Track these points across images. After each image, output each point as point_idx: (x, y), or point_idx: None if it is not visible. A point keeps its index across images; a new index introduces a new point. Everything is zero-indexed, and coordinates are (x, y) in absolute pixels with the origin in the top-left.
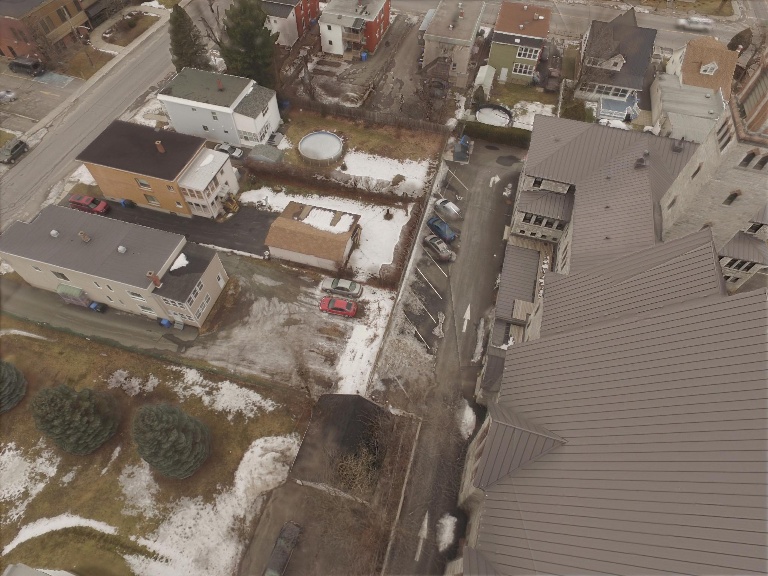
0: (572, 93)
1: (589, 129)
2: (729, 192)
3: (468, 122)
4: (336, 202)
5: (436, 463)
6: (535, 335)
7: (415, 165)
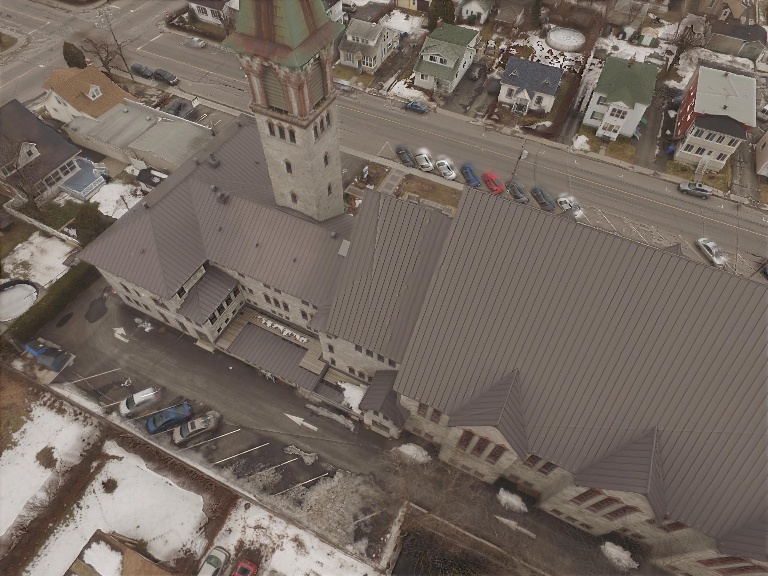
0: (36, 208)
1: (151, 218)
2: (323, 158)
3: (6, 334)
4: (38, 569)
5: (452, 496)
6: (360, 360)
7: (32, 426)
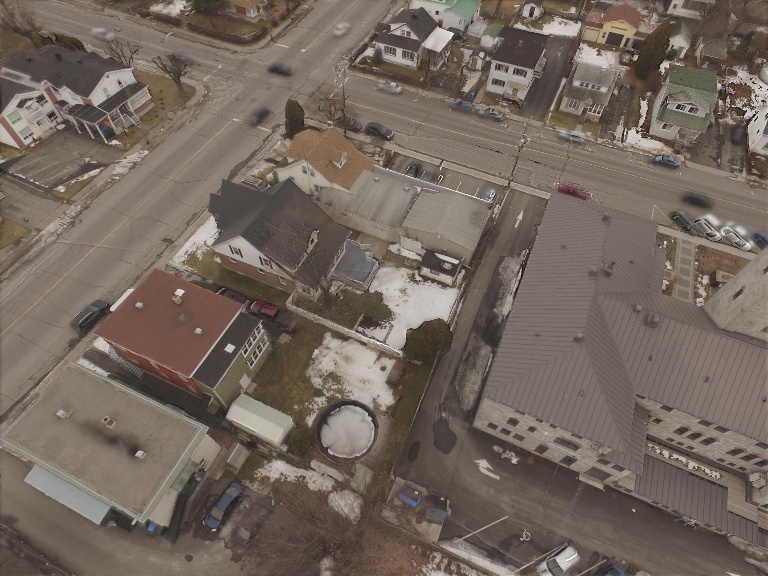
0: None
1: (588, 352)
2: None
3: (378, 481)
4: None
5: None
6: None
7: None
